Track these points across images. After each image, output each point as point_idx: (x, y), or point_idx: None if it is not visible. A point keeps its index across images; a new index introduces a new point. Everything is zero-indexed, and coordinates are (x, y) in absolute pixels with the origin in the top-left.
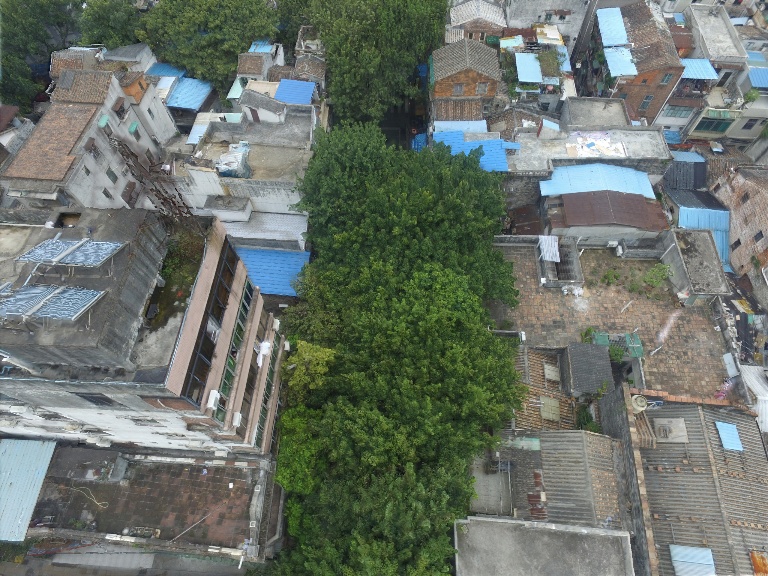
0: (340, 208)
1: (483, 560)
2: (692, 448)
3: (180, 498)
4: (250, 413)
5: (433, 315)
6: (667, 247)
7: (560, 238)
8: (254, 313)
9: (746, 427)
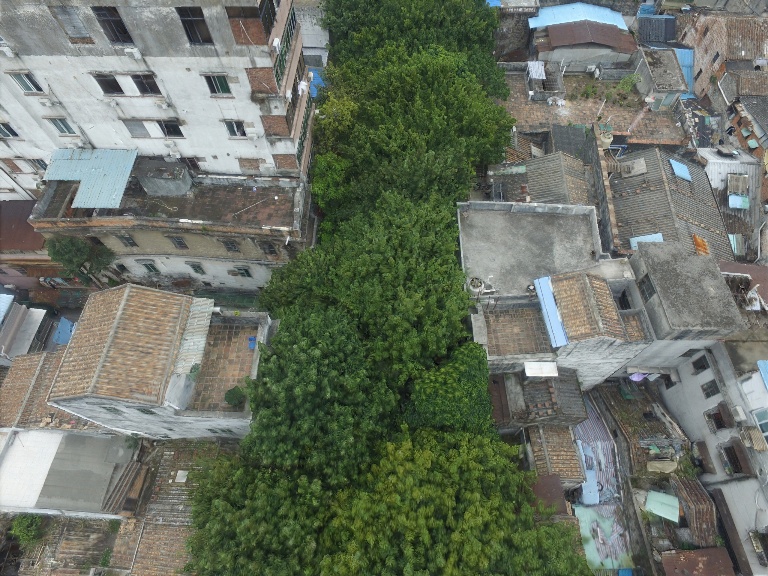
0: (358, 18)
1: (480, 232)
2: (650, 176)
3: (236, 205)
4: (294, 121)
5: (439, 59)
6: (637, 65)
7: (546, 63)
8: (297, 39)
9: (696, 172)
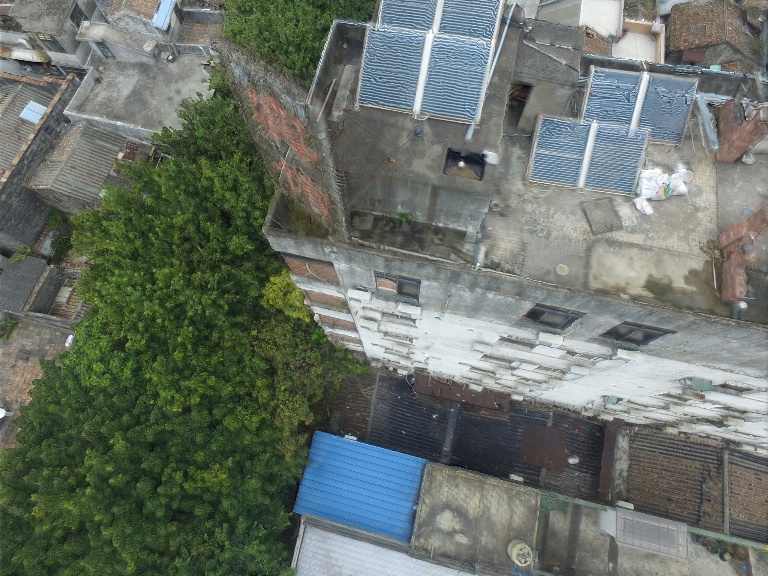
0: None
1: None
2: None
3: None
4: None
5: (116, 278)
6: None
7: None
8: None
9: None
